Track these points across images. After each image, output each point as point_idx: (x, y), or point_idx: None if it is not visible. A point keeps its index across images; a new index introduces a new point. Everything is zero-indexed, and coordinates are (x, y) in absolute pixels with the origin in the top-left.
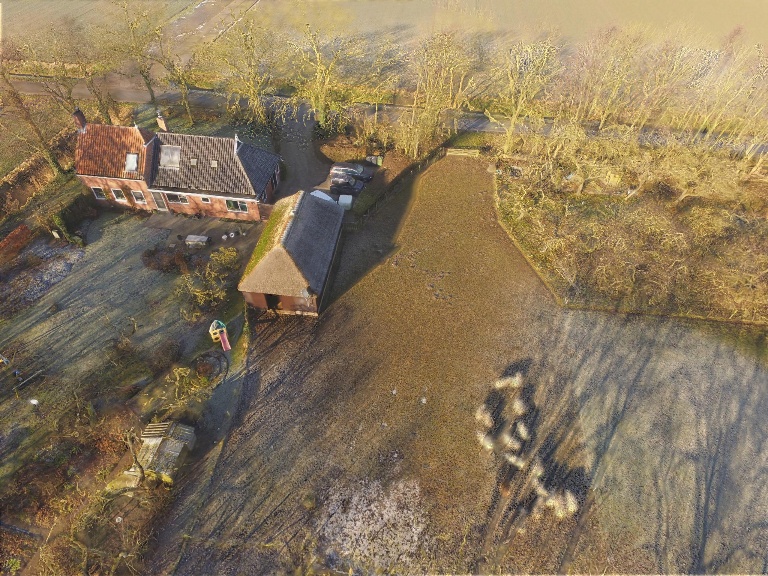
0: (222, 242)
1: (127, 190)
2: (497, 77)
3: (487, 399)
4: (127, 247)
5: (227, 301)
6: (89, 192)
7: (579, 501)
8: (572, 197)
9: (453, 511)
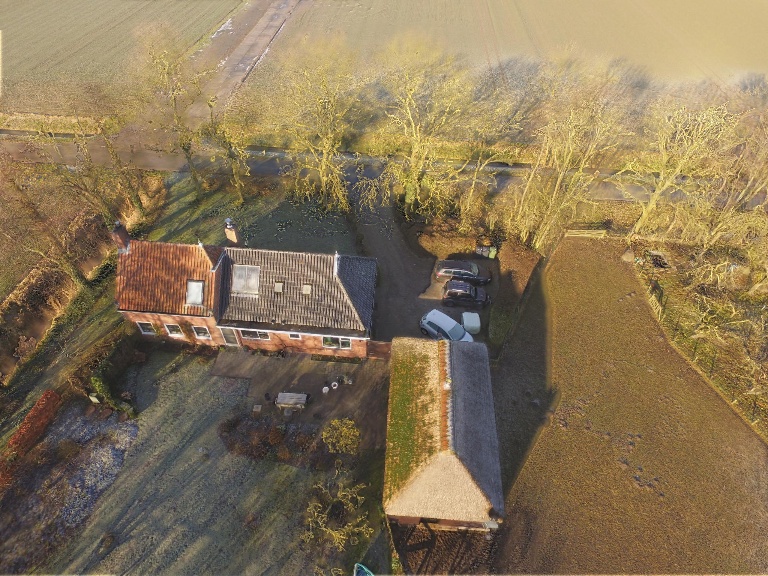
0: (323, 397)
1: (187, 326)
2: None
3: None
4: (196, 414)
5: (355, 509)
6: (134, 329)
7: None
8: (744, 298)
9: None
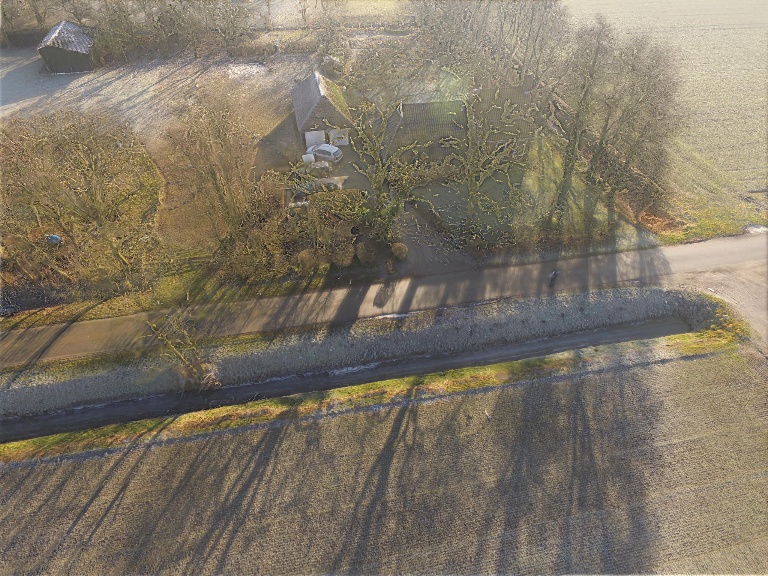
0: None
1: None
2: (46, 575)
3: (197, 98)
4: None
5: None
6: None
7: (163, 82)
8: None
9: (216, 75)
